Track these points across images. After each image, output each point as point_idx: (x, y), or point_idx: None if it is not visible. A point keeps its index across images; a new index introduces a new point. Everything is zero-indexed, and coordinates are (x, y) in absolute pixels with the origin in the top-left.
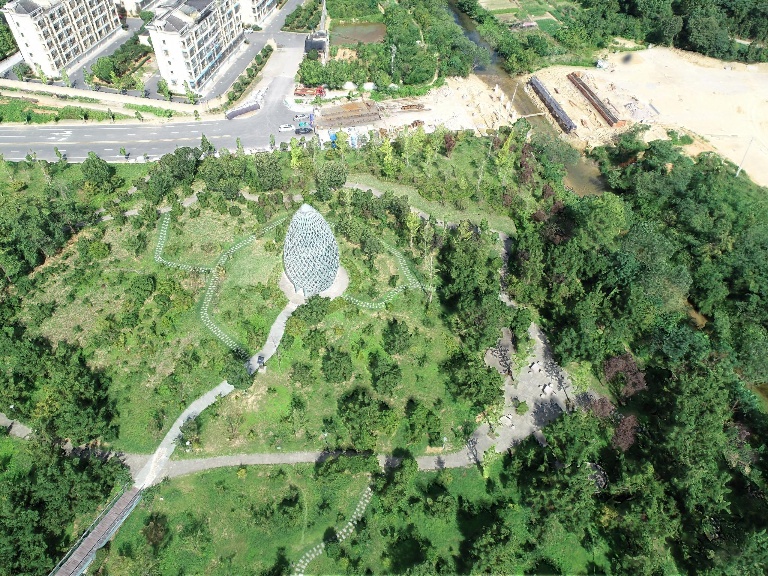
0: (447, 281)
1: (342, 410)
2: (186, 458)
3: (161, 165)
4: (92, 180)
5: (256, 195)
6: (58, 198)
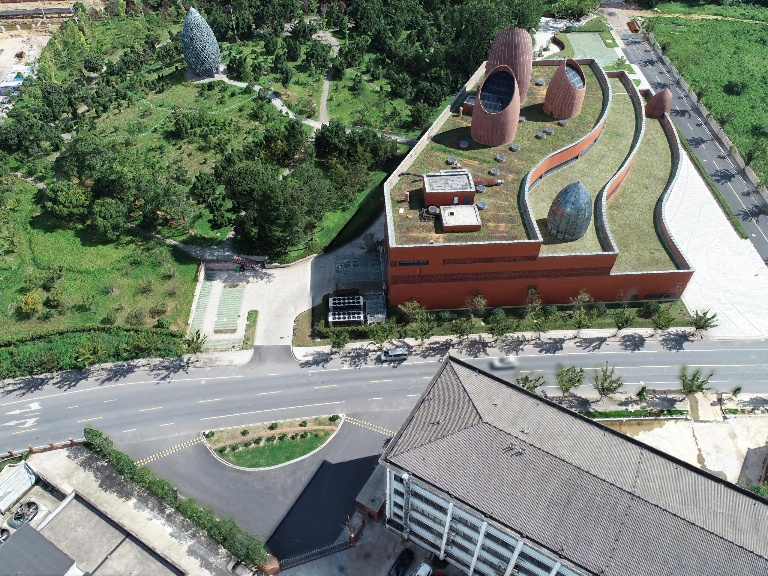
0: (225, 40)
1: (311, 58)
2: (319, 116)
3: (12, 137)
4: (3, 175)
5: (82, 107)
6: (6, 205)
